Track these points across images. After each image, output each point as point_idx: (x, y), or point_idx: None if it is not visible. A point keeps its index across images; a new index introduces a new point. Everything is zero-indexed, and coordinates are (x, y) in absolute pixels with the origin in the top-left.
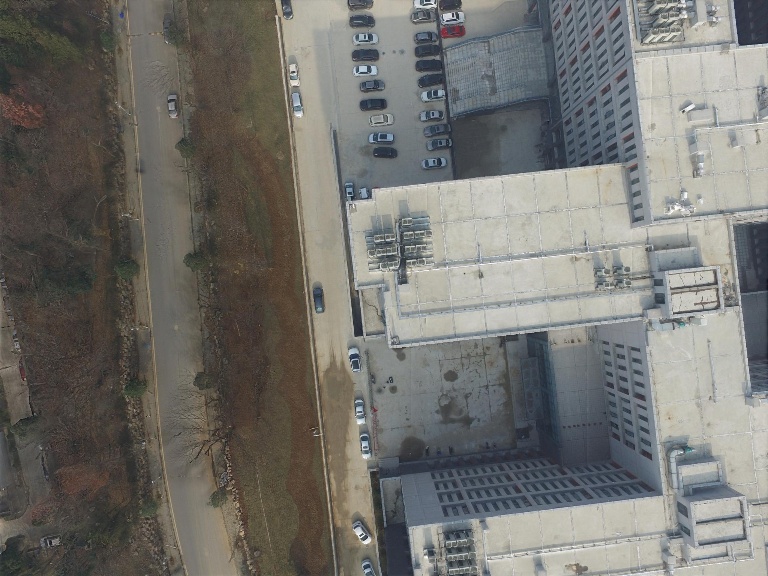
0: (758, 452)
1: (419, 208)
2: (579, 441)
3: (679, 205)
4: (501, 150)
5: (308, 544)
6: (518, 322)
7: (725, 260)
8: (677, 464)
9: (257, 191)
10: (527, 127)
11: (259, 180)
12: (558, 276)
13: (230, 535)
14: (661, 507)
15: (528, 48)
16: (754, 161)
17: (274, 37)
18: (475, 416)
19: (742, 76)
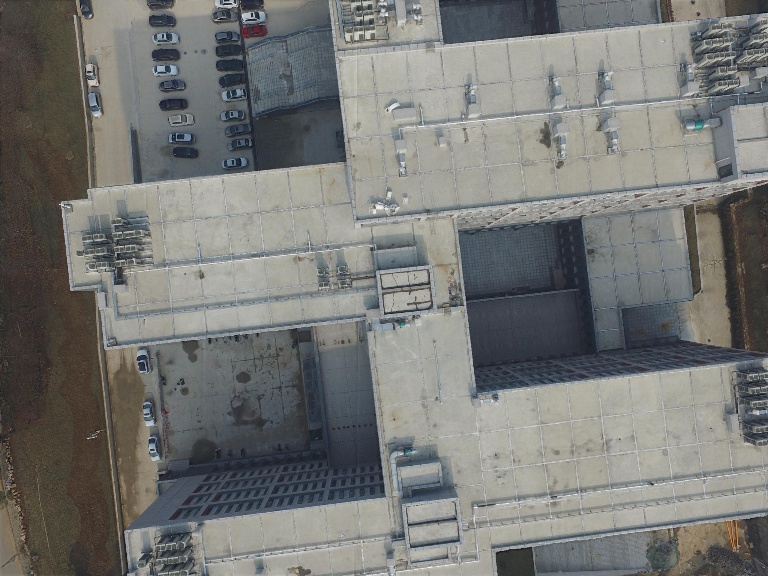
0: (485, 453)
1: (138, 208)
2: (349, 443)
3: (382, 204)
4: (304, 150)
5: (91, 548)
6: (239, 323)
7: (451, 260)
8: (397, 465)
9: (45, 192)
10: (331, 127)
11: (48, 180)
12: (281, 276)
13: (16, 539)
14: (386, 509)
15: (321, 48)
16: (462, 160)
17: (72, 37)
18: (268, 418)
19: (449, 75)
